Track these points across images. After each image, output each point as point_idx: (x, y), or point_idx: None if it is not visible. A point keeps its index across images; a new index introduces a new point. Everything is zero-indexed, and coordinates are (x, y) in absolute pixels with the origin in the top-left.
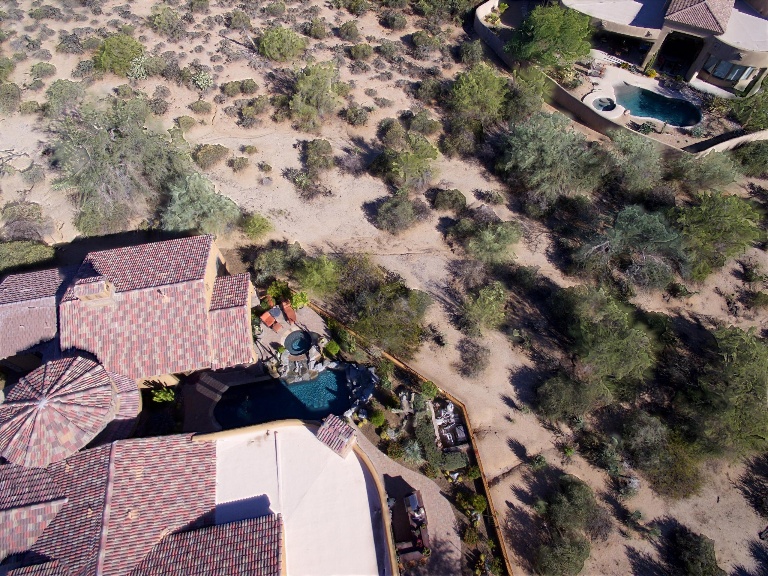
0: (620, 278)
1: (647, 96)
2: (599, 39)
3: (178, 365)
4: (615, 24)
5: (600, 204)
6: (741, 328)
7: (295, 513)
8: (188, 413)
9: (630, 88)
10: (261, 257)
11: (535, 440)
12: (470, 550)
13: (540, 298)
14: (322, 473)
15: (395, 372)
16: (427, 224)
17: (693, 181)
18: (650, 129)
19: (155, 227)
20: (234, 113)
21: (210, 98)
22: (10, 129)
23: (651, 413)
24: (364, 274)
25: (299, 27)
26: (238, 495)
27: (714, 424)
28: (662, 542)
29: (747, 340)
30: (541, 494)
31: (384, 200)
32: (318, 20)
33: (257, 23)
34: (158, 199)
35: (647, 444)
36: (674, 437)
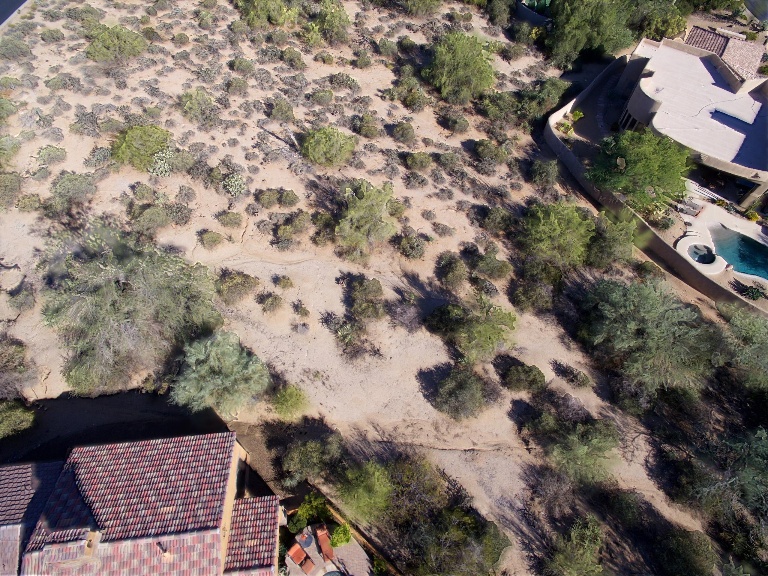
0: (742, 514)
1: (748, 243)
2: (688, 165)
3: None
4: (717, 160)
5: (705, 393)
6: None
7: None
8: None
9: (728, 232)
10: (293, 456)
11: None
12: None
13: (643, 539)
14: None
15: None
16: (497, 409)
17: None
18: (759, 293)
19: (162, 392)
20: (268, 230)
21: (241, 207)
22: (3, 229)
23: None
24: (423, 495)
25: (347, 121)
26: None
27: None
28: None
29: None
30: None
31: (444, 368)
32: (370, 116)
33: (300, 112)
34: (169, 350)
35: None
36: None
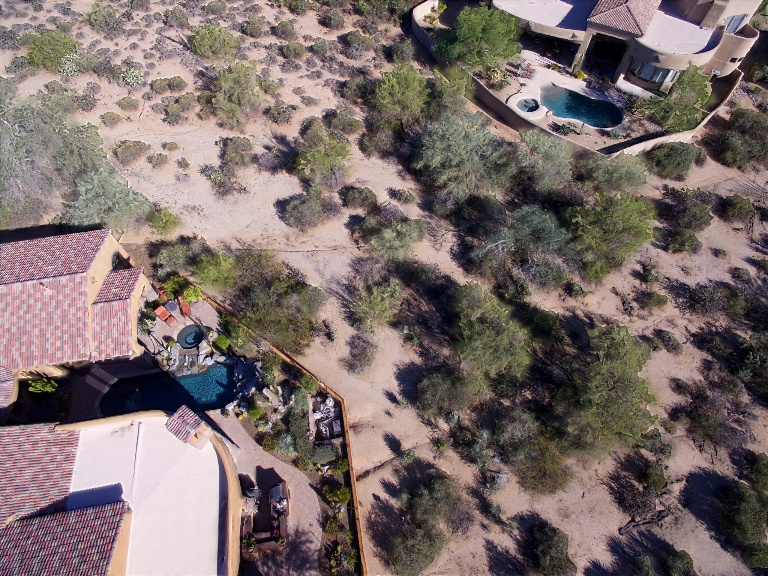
0: (519, 277)
1: (574, 97)
2: (533, 40)
3: (56, 356)
4: (541, 25)
5: (511, 204)
6: (633, 328)
7: (145, 501)
8: (74, 404)
9: (557, 89)
10: (162, 252)
11: (411, 435)
12: (330, 541)
13: (437, 296)
14: (178, 463)
15: (282, 366)
16: (336, 221)
17: (605, 182)
18: (570, 130)
19: (65, 221)
20: (160, 110)
21: (139, 95)
22: None
23: (530, 410)
24: (261, 270)
25: (237, 25)
26: (93, 483)
27: (577, 421)
28: (521, 536)
29: (619, 339)
30: (409, 487)
31: (297, 197)
32: (255, 19)
33: (196, 21)
34: (72, 194)
35: (514, 440)
36: (545, 433)
